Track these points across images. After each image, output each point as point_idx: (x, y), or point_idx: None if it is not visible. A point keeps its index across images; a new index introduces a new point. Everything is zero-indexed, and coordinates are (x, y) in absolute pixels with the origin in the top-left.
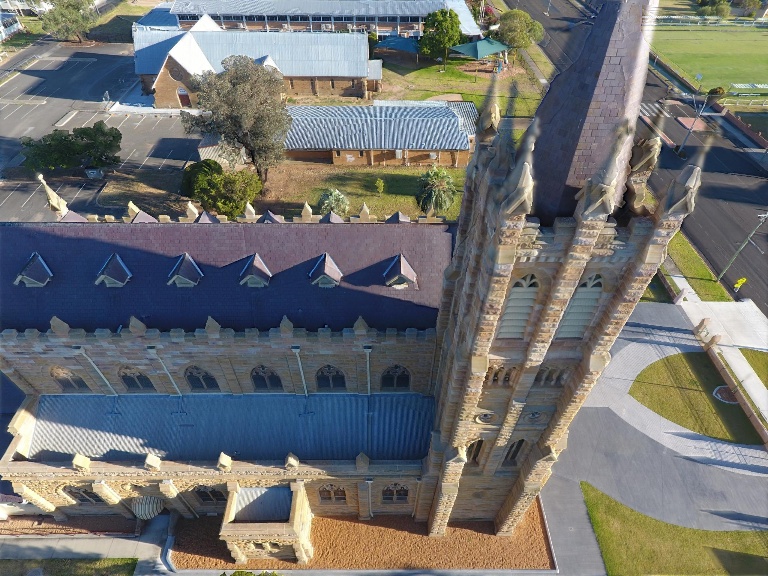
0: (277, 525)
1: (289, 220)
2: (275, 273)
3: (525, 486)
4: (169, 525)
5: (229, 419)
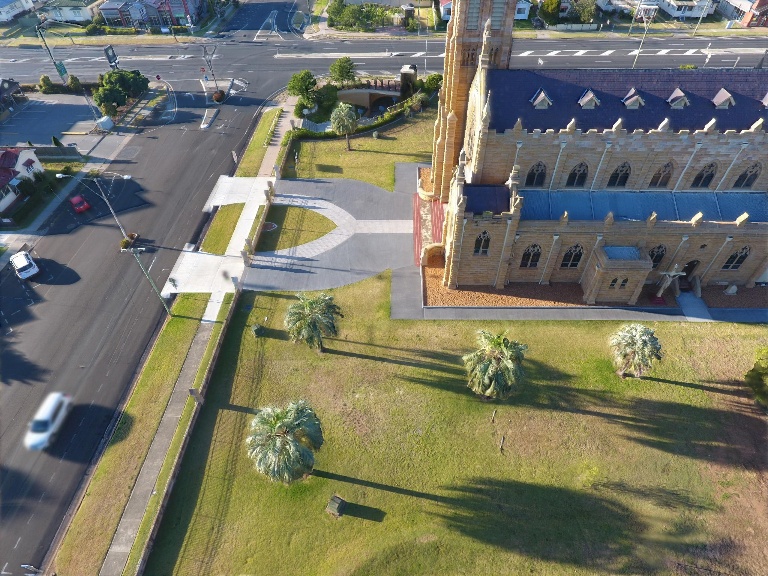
0: None
1: (630, 134)
2: None
3: None
4: None
5: None
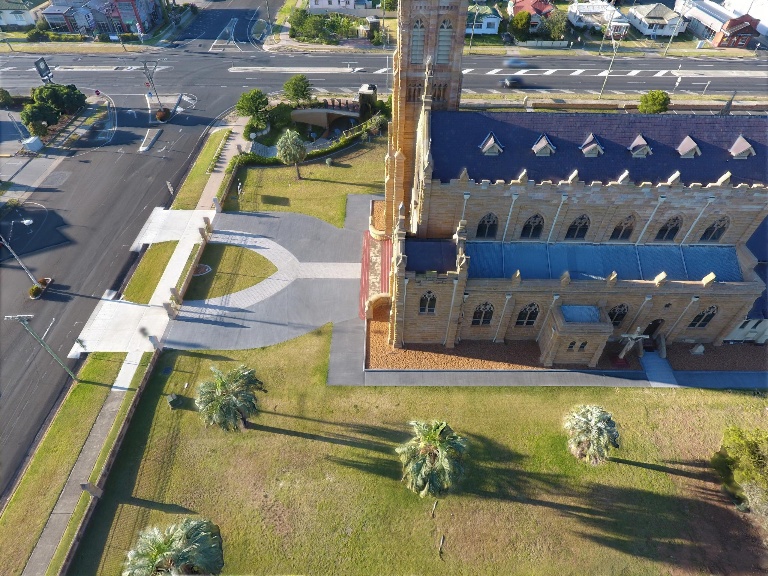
0: None
1: (588, 186)
2: None
3: None
4: None
5: None
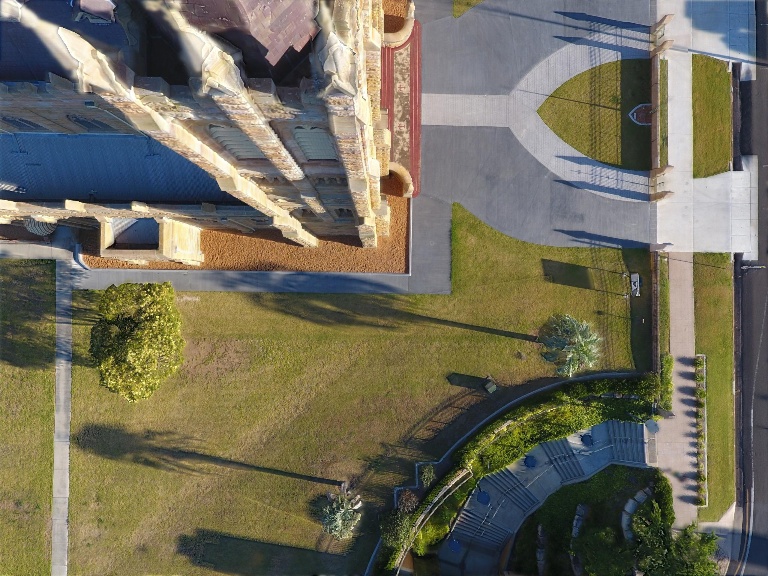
0: (148, 252)
1: None
2: (23, 2)
3: (360, 234)
4: (72, 236)
5: (74, 159)
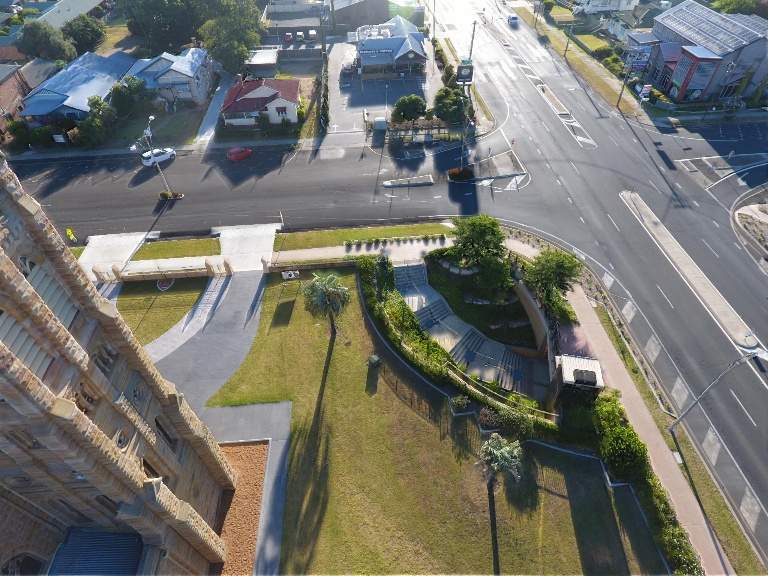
0: None
1: None
2: None
3: (198, 435)
4: None
5: None
